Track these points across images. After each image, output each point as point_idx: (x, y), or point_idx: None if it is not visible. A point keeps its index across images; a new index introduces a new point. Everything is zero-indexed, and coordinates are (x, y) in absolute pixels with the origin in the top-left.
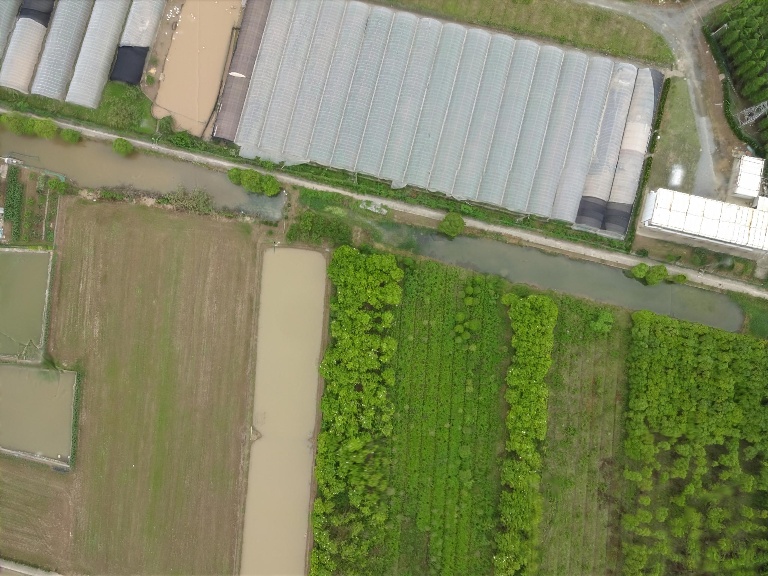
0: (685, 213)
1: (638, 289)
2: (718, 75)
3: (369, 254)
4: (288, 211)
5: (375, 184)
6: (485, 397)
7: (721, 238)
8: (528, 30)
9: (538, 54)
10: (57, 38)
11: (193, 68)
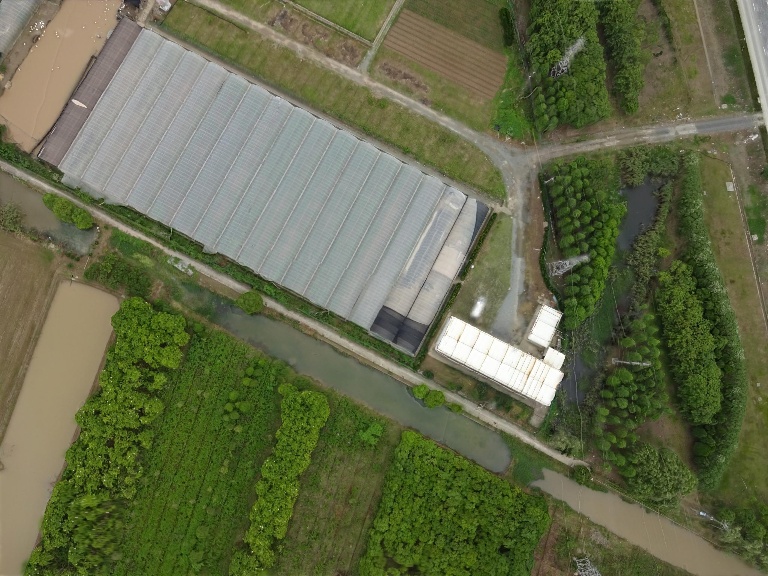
0: (471, 347)
1: (417, 409)
2: (543, 222)
3: (161, 311)
4: (94, 248)
5: (188, 243)
6: (239, 481)
7: (499, 380)
8: (376, 133)
9: (377, 159)
10: None
11: (42, 84)
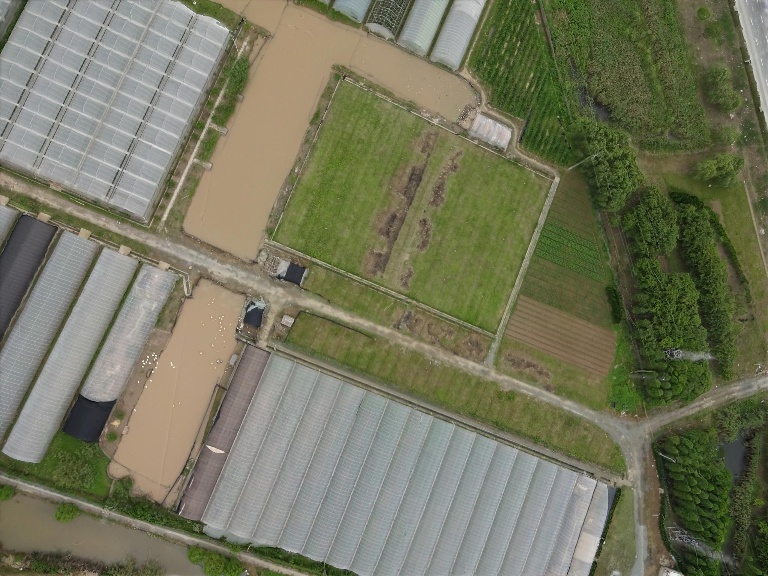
0: None
1: None
2: (658, 488)
3: None
4: None
5: (343, 572)
6: None
7: None
8: (508, 427)
9: (515, 458)
10: (4, 380)
11: (164, 424)
